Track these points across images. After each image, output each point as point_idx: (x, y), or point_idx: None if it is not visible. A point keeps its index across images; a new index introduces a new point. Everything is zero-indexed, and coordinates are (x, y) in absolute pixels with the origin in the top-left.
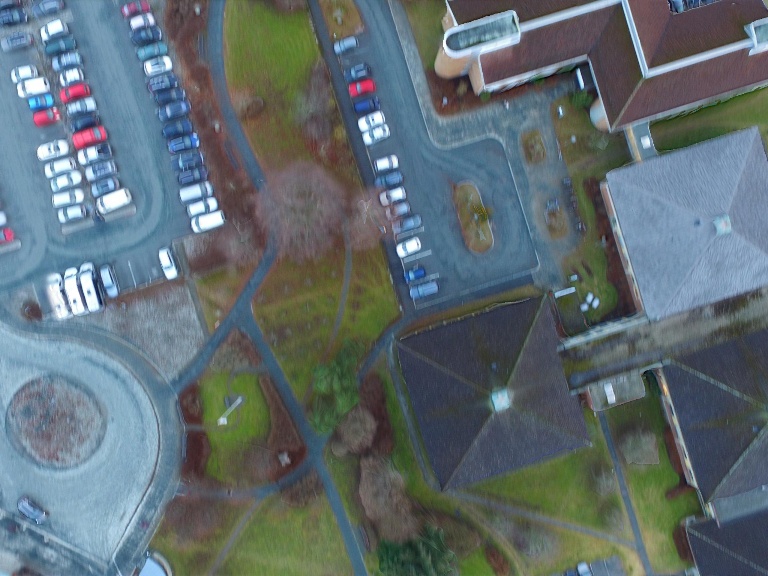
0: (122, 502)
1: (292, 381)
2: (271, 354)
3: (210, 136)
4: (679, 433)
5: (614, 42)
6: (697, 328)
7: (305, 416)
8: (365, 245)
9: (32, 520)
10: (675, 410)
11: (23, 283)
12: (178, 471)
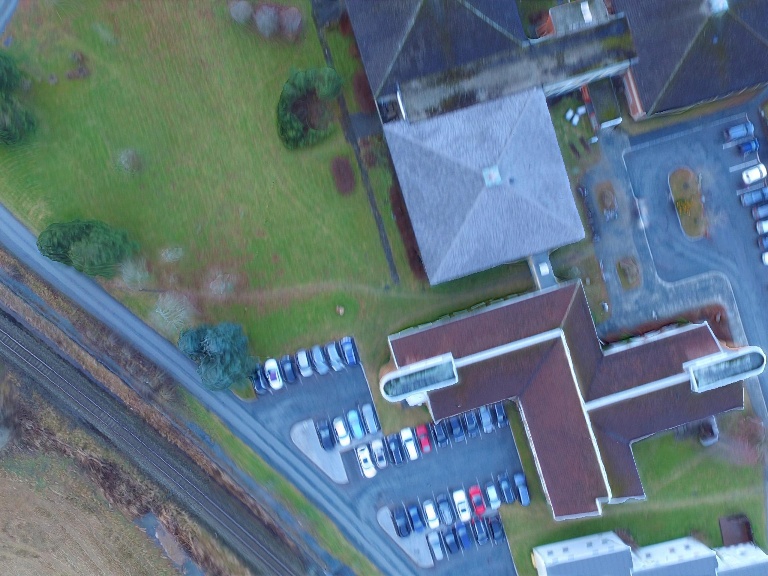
0: None
1: None
2: None
3: None
4: None
5: (586, 366)
6: (495, 78)
7: None
8: None
9: None
10: None
11: None
12: None
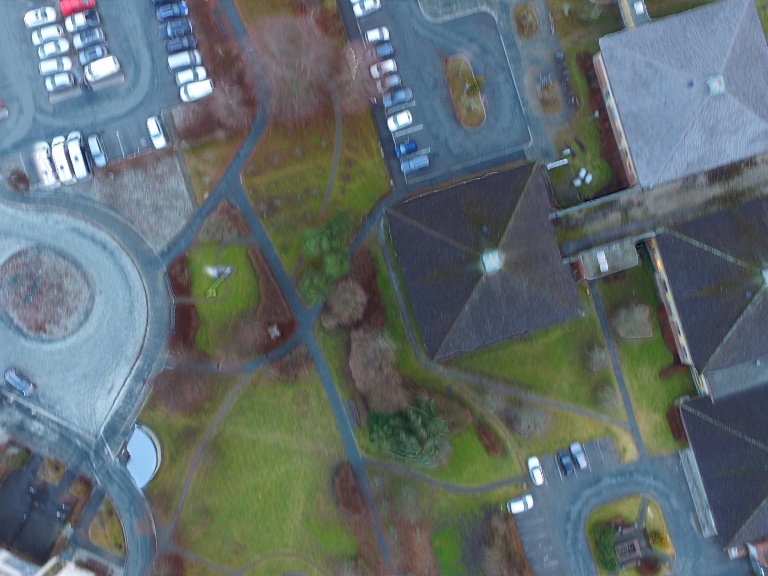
0: (110, 375)
1: (282, 254)
2: (260, 226)
3: (199, 4)
4: (673, 309)
5: None
6: (691, 196)
7: (295, 289)
8: (355, 117)
9: (19, 392)
10: (668, 280)
11: (10, 152)
12: (167, 344)
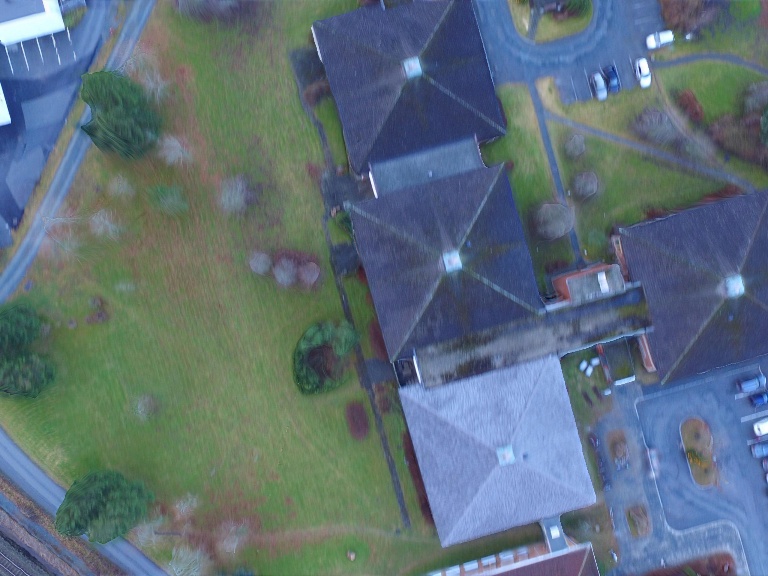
0: None
1: None
2: None
3: None
4: None
5: None
6: (510, 345)
7: None
8: None
9: None
10: None
11: None
12: None
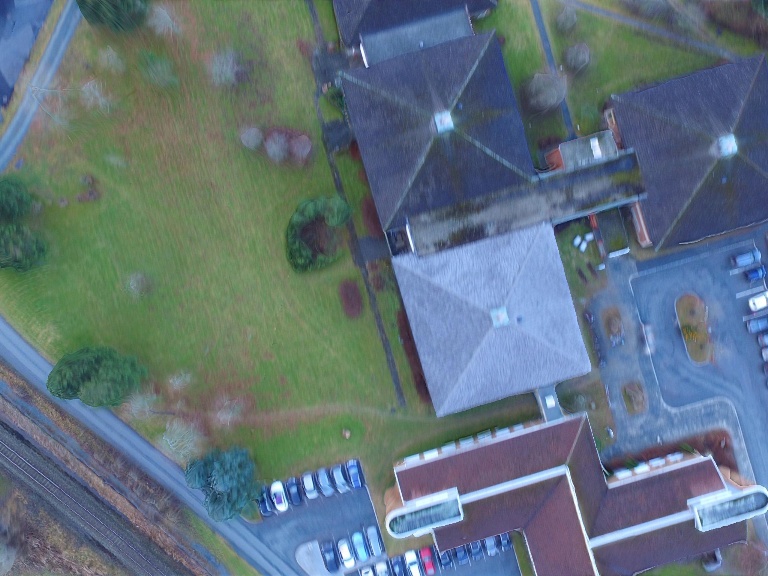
0: None
1: None
2: None
3: None
4: None
5: (591, 501)
6: (503, 213)
7: None
8: None
9: None
10: None
11: None
12: None
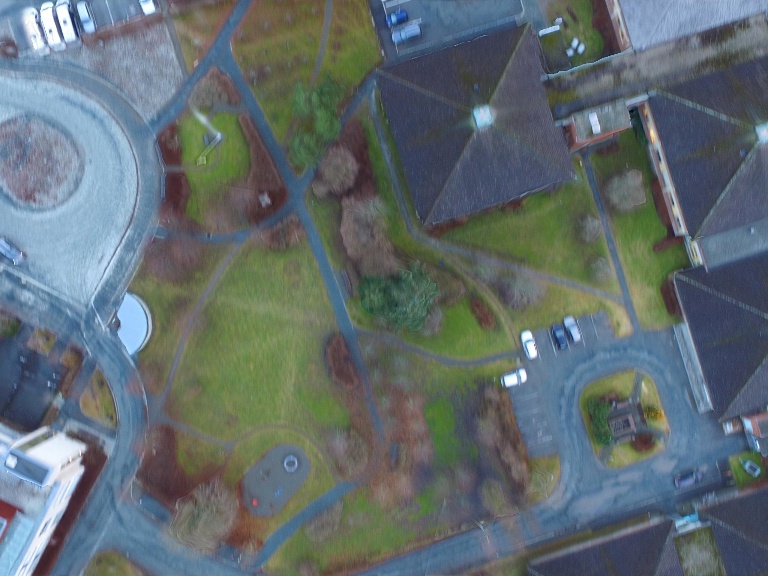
0: (100, 245)
1: (272, 122)
2: (251, 94)
3: None
4: (666, 178)
5: None
6: (683, 58)
7: (286, 157)
8: None
9: (9, 262)
10: (661, 144)
11: None
12: (157, 213)
